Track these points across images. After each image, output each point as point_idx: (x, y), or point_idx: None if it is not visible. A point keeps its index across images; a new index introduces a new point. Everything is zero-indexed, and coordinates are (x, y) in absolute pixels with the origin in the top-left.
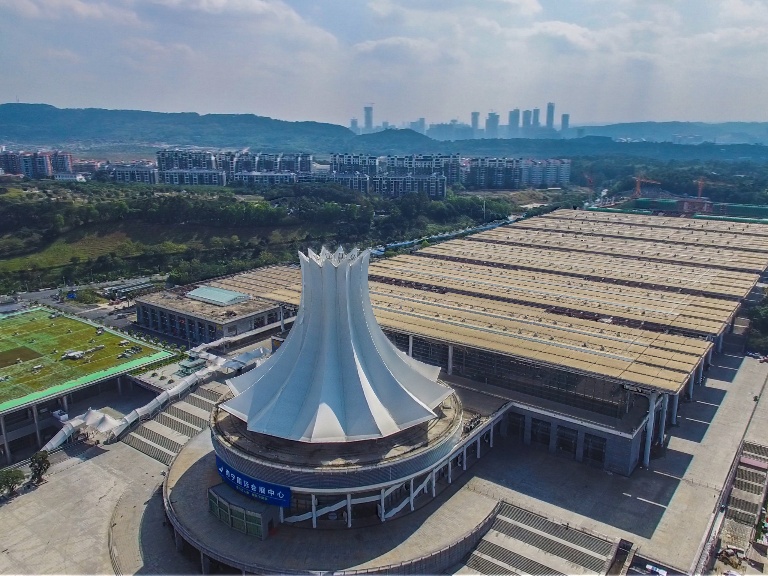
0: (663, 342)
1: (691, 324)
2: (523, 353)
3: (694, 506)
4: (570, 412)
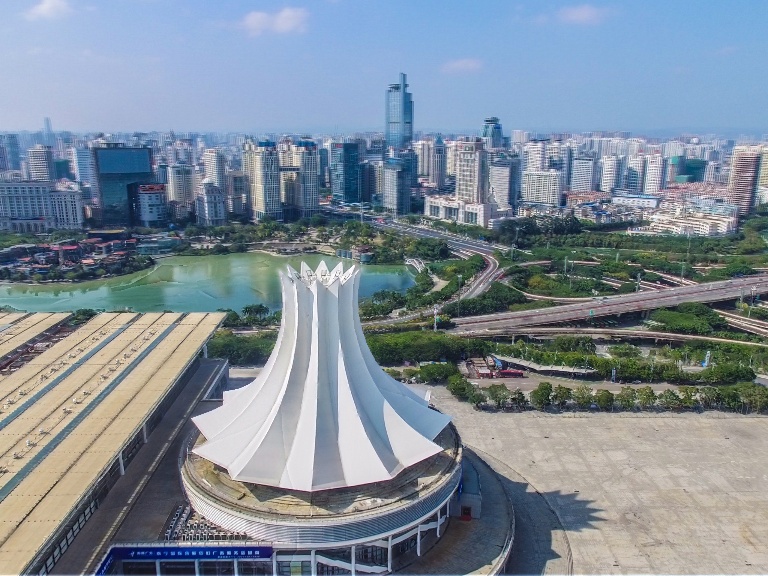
0: (117, 321)
1: (45, 320)
2: (189, 353)
3: (252, 372)
4: (203, 379)
